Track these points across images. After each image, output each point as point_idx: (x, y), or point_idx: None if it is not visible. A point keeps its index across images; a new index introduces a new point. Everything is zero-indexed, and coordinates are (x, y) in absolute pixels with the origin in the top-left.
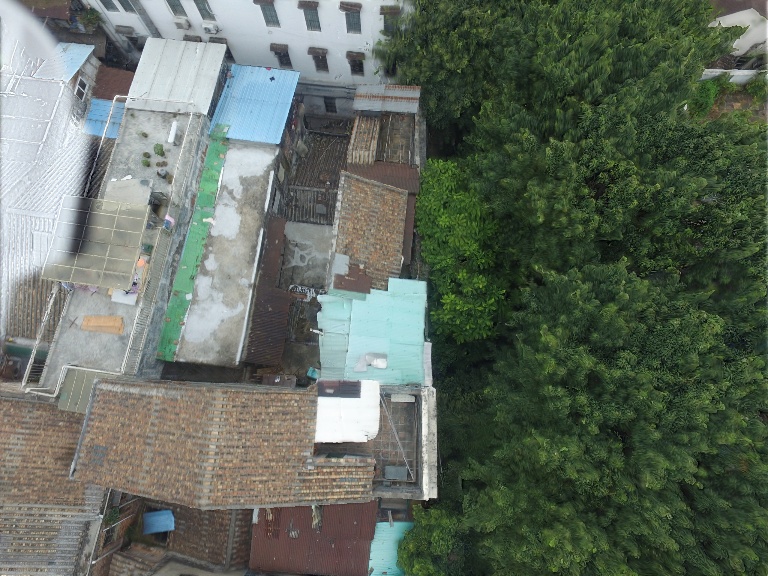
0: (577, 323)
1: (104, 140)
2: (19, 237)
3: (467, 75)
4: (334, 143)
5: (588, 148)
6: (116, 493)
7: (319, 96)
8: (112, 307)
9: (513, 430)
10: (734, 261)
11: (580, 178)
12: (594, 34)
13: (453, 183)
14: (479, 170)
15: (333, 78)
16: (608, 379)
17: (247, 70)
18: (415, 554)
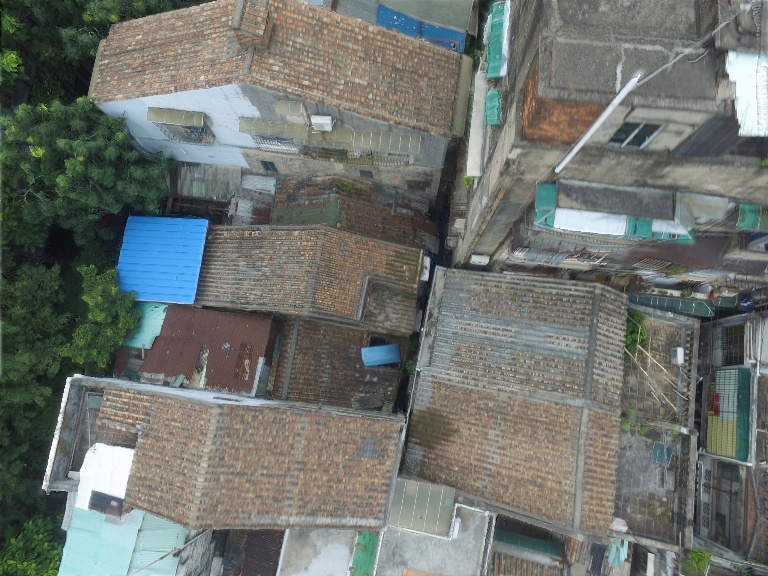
0: None
1: None
2: None
3: None
4: None
5: None
6: None
7: None
8: None
9: None
10: None
11: None
12: None
13: None
14: None
15: None
16: None
17: None
18: (112, 325)
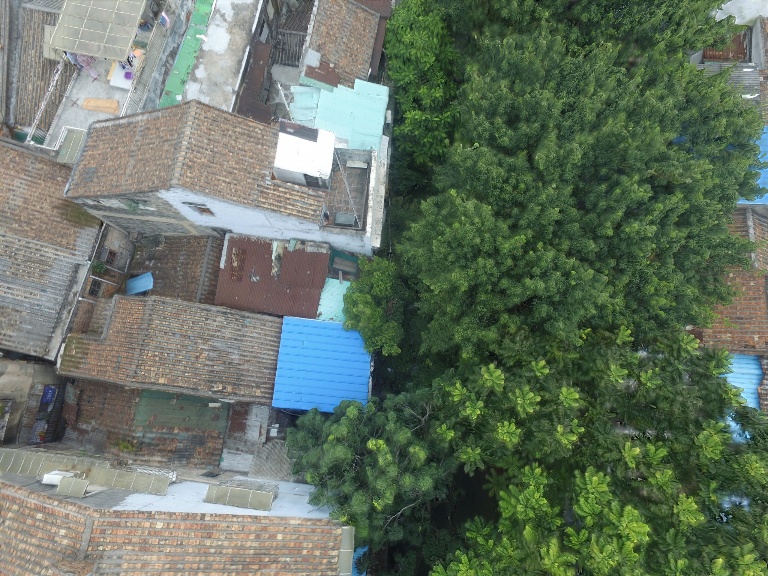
0: (505, 78)
1: None
2: (32, 31)
3: None
4: None
5: None
6: (103, 251)
7: None
8: (110, 92)
9: None
10: (644, 34)
11: None
12: None
13: (420, 8)
14: None
15: None
16: (522, 106)
17: None
18: None
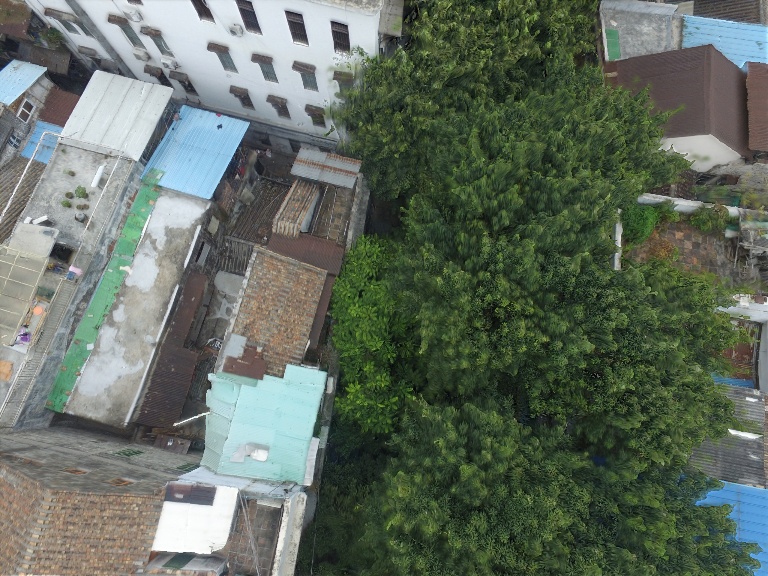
0: (442, 468)
1: (41, 166)
2: None
3: (411, 156)
4: (284, 193)
5: (486, 281)
6: None
7: (283, 138)
8: (4, 351)
9: (377, 554)
10: (619, 427)
11: (477, 308)
12: (508, 163)
13: (374, 270)
14: (396, 266)
15: (296, 124)
16: (452, 545)
17: (197, 113)
18: None
